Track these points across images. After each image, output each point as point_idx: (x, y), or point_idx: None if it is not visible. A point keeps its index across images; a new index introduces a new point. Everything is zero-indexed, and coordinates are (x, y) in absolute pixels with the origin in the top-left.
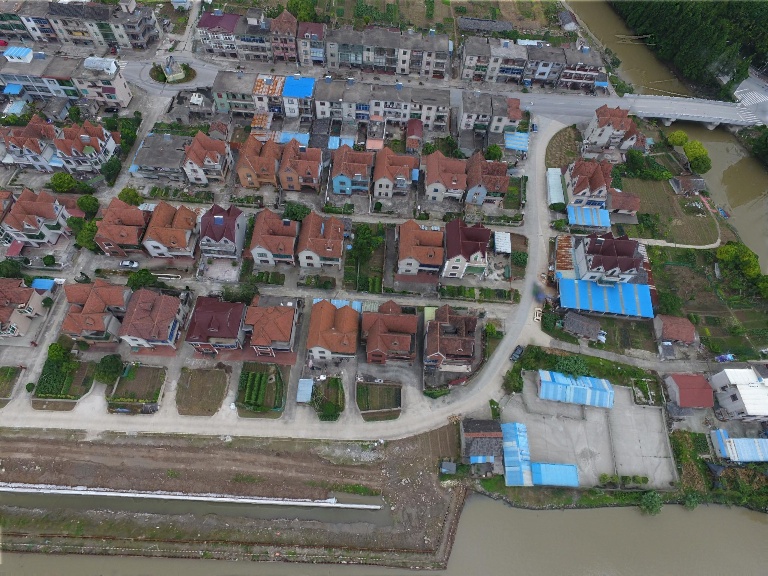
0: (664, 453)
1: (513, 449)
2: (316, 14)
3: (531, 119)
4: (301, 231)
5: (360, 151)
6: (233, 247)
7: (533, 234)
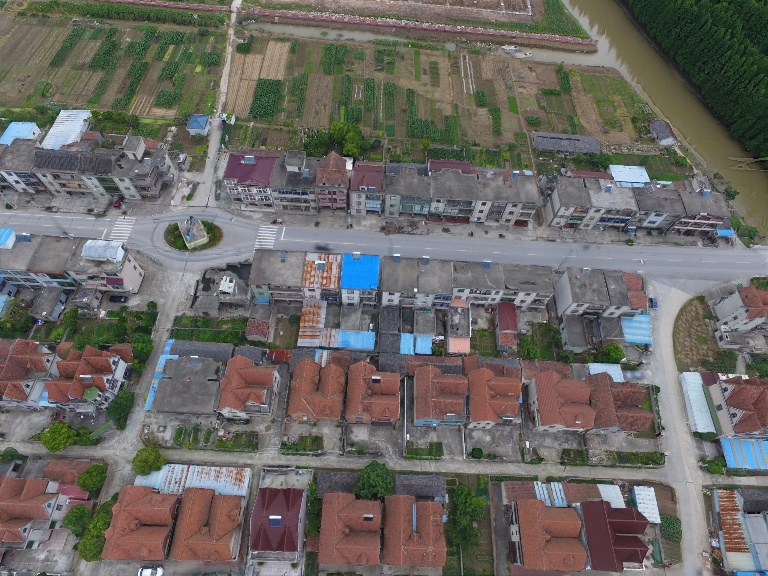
0: None
1: None
2: (363, 136)
3: (645, 288)
4: (386, 521)
5: (443, 358)
6: (296, 558)
7: (680, 481)
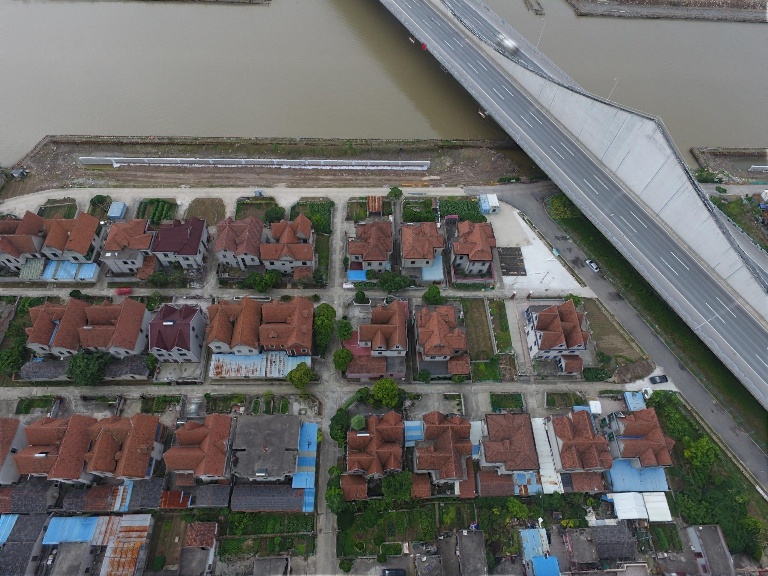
0: None
1: None
2: None
3: None
4: None
5: None
6: (162, 306)
7: None
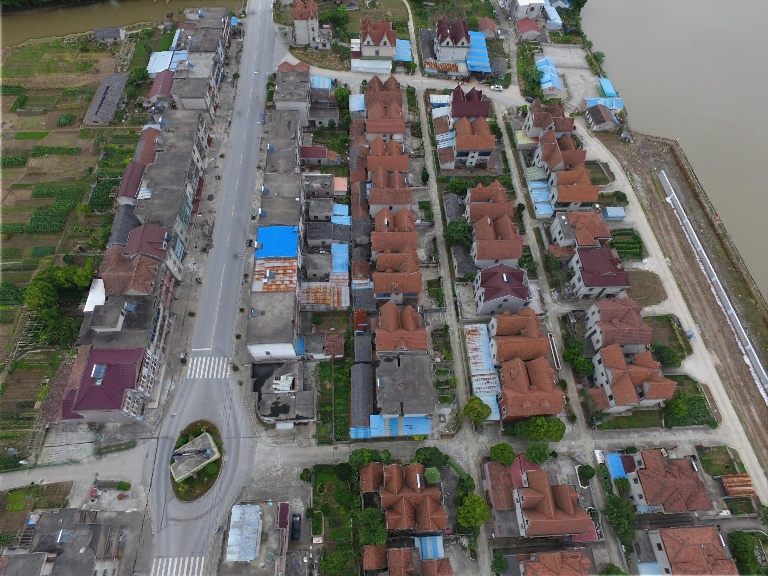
0: (567, 49)
1: (603, 103)
2: None
3: None
4: None
5: (354, 194)
6: None
7: (422, 85)
